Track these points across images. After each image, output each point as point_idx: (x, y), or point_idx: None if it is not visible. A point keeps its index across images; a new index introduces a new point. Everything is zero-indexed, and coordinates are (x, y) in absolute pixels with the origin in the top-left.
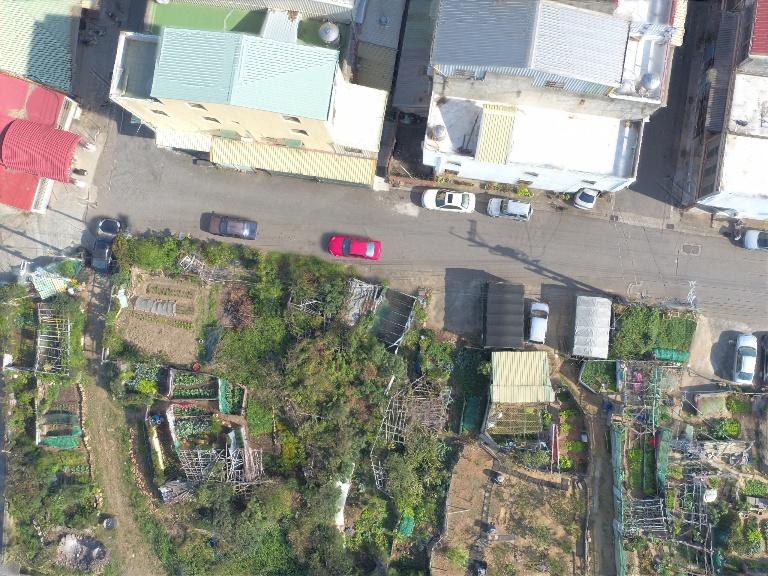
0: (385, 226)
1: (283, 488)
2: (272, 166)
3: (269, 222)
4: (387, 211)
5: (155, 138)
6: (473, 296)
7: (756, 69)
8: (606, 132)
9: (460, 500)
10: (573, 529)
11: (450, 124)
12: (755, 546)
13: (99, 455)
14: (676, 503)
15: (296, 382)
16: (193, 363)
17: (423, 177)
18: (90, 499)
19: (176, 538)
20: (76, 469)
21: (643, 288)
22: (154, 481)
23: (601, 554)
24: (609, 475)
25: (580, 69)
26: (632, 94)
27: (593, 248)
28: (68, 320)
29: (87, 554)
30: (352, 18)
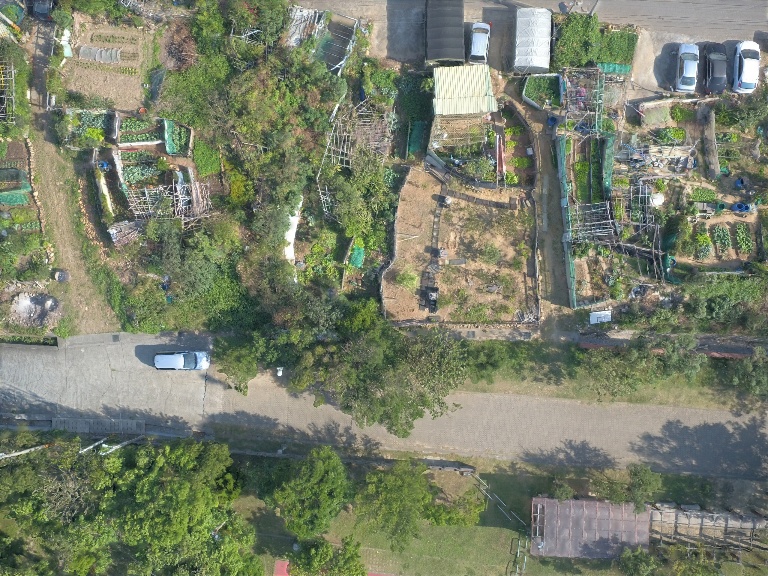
0: None
1: (231, 219)
2: None
3: None
4: None
5: None
6: (415, 23)
7: None
8: None
9: (409, 227)
10: (523, 249)
11: None
12: (704, 249)
13: (49, 210)
14: (624, 214)
15: (240, 112)
16: (139, 108)
17: None
18: (42, 255)
19: (128, 285)
20: (27, 226)
21: (584, 6)
22: (102, 221)
23: (552, 273)
24: (557, 190)
25: None
26: None
27: None
28: (12, 66)
29: (41, 313)
30: None
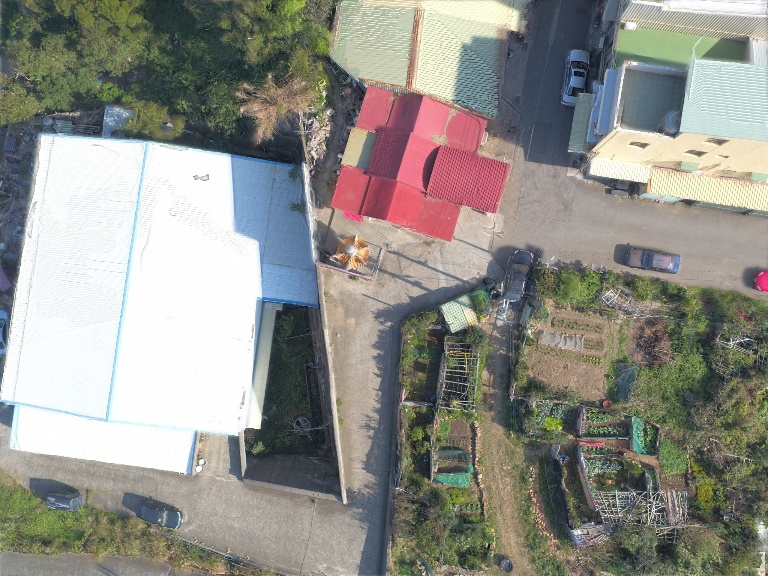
0: None
1: (711, 533)
2: (714, 199)
3: (688, 255)
4: None
5: (589, 168)
6: None
7: None
8: None
9: None
10: None
11: None
12: None
13: (493, 493)
14: None
15: (726, 423)
16: (602, 400)
17: None
18: None
19: None
20: (467, 507)
21: None
22: (570, 523)
23: None
24: None
25: None
26: None
27: None
28: (478, 354)
29: None
30: None
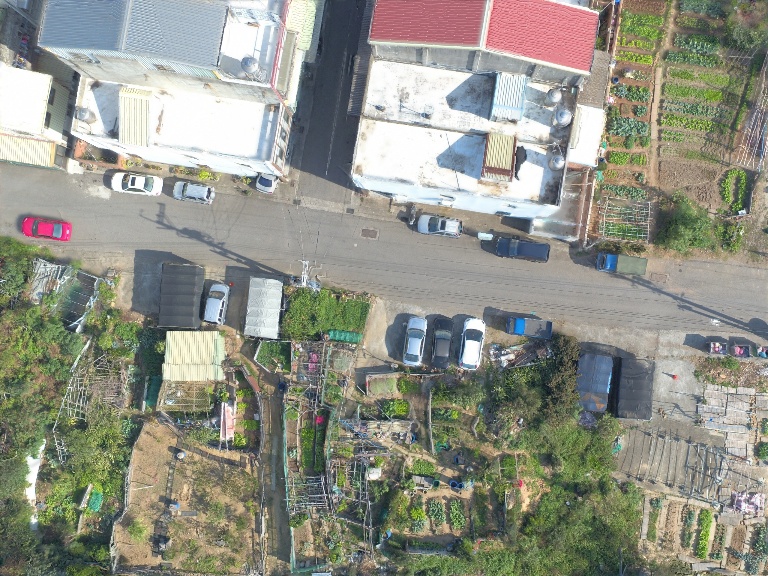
0: (78, 208)
1: None
2: None
3: None
4: (80, 194)
5: None
6: (160, 277)
7: (390, 55)
8: (251, 116)
9: (145, 476)
10: (252, 506)
11: (103, 107)
12: (418, 524)
13: None
14: (346, 481)
15: None
16: None
17: (114, 161)
18: None
19: None
20: None
21: (323, 271)
22: None
23: (279, 531)
24: None
25: (173, 52)
26: (246, 78)
27: (276, 231)
28: None
29: None
30: (10, 3)
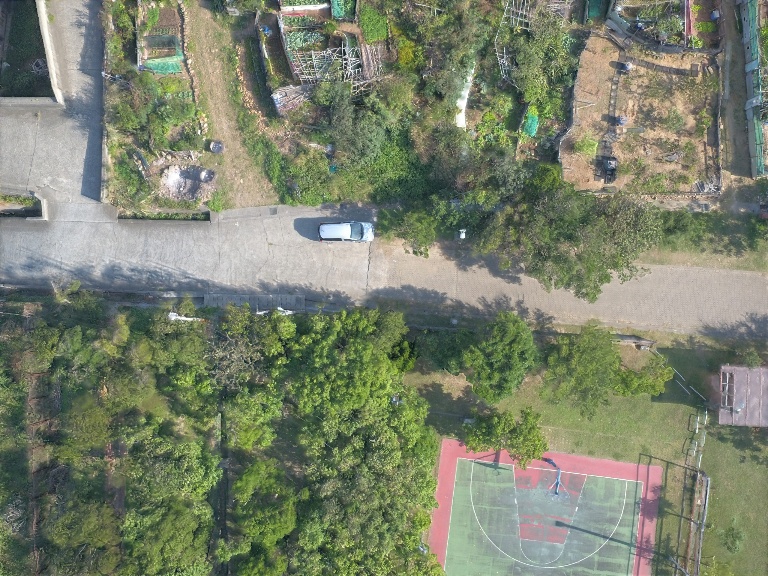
0: None
1: (404, 82)
2: None
3: None
4: None
5: None
6: None
7: None
8: None
9: (586, 94)
10: (704, 118)
11: None
12: None
13: (203, 79)
14: None
15: None
16: None
17: None
18: (194, 126)
19: (288, 155)
20: (178, 95)
21: None
22: (267, 84)
23: (733, 143)
24: (740, 56)
25: None
26: None
27: None
28: None
29: (191, 187)
30: None
